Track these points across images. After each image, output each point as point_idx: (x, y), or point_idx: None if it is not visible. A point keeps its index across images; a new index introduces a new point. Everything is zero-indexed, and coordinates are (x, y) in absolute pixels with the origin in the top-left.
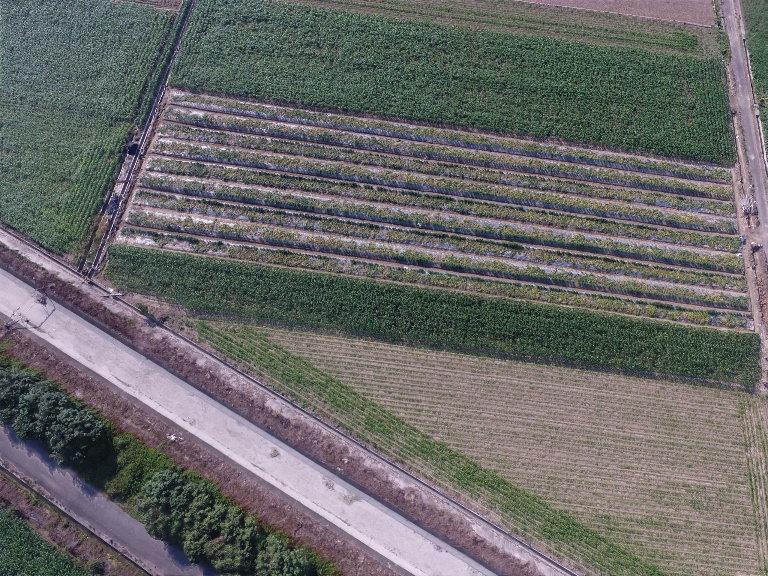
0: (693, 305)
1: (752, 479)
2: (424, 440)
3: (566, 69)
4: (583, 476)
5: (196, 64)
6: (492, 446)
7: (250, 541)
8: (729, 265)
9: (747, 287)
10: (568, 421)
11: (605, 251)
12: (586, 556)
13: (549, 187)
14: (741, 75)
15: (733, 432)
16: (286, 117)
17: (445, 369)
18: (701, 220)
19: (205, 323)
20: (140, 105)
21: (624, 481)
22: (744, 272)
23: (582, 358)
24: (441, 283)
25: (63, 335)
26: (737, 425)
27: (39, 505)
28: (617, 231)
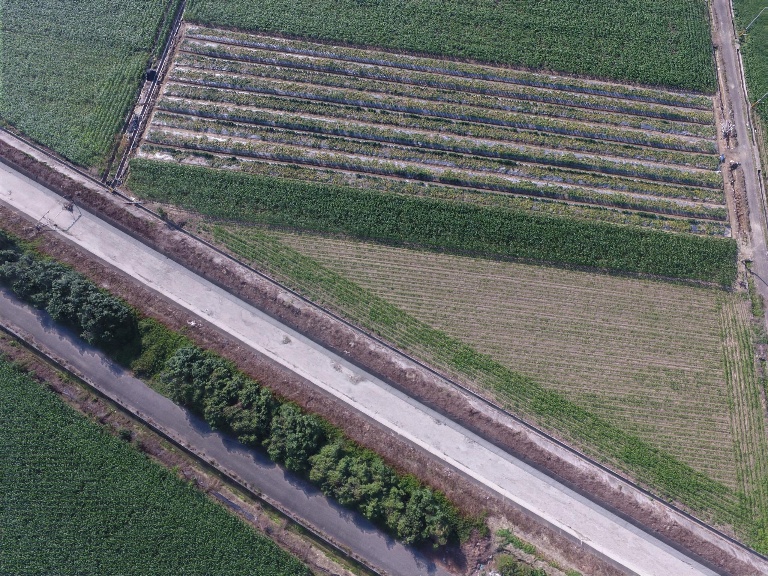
0: (675, 215)
1: (727, 364)
2: (424, 329)
3: (558, 7)
4: (571, 361)
5: (209, 1)
6: (487, 335)
7: (265, 406)
8: (709, 180)
9: (725, 200)
10: (557, 314)
11: (593, 168)
12: (573, 428)
13: (541, 111)
14: (723, 14)
15: (710, 324)
16: (294, 49)
17: (444, 269)
18: (683, 141)
19: (221, 228)
20: (157, 37)
21: (609, 366)
22: (723, 187)
23: (571, 259)
24: (440, 194)
25: (89, 238)
26: (714, 318)
27: (70, 383)
28: (605, 150)
